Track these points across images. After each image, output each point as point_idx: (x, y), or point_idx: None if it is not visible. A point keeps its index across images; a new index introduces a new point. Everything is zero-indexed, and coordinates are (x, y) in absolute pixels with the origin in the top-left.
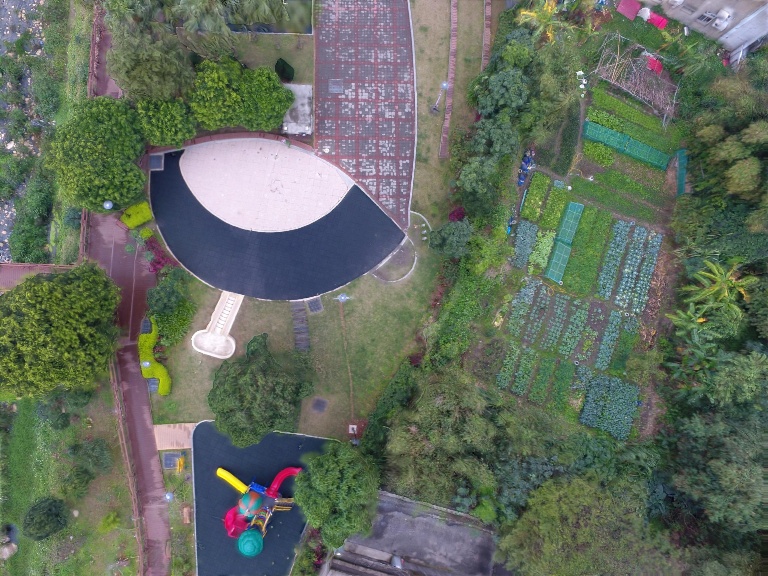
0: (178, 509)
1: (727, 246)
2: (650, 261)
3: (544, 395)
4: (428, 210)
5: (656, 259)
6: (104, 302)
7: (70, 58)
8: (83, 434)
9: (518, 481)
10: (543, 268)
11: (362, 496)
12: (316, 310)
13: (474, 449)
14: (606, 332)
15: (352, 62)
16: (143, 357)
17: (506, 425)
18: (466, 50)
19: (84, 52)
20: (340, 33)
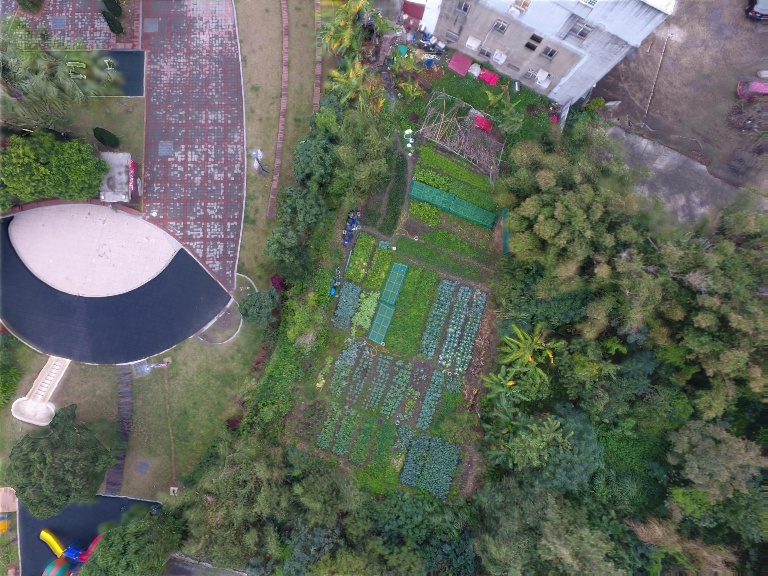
0: (2, 571)
1: (538, 309)
2: (474, 320)
3: (364, 455)
4: (254, 272)
5: (480, 318)
6: None
7: None
8: None
9: (299, 554)
10: (367, 329)
11: (137, 573)
12: (142, 373)
13: (274, 516)
14: (427, 392)
15: (182, 124)
16: None
17: (302, 494)
18: (296, 109)
19: None
20: (171, 95)
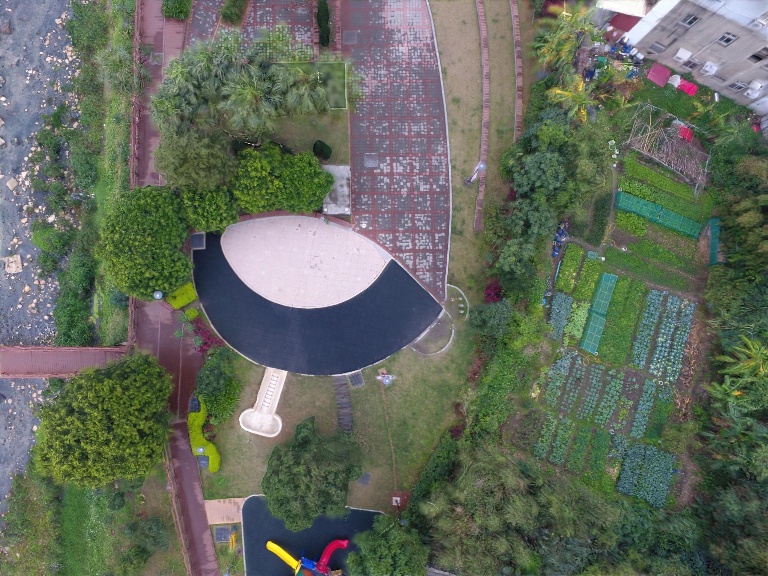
0: None
1: (761, 319)
2: (683, 329)
3: (581, 464)
4: (464, 283)
5: (689, 327)
6: (159, 393)
7: (108, 135)
8: (136, 510)
9: (564, 564)
10: (578, 339)
11: None
12: (357, 384)
13: None
14: (641, 401)
15: (386, 136)
16: (193, 436)
17: (549, 504)
18: (498, 121)
19: (124, 132)
20: (374, 106)
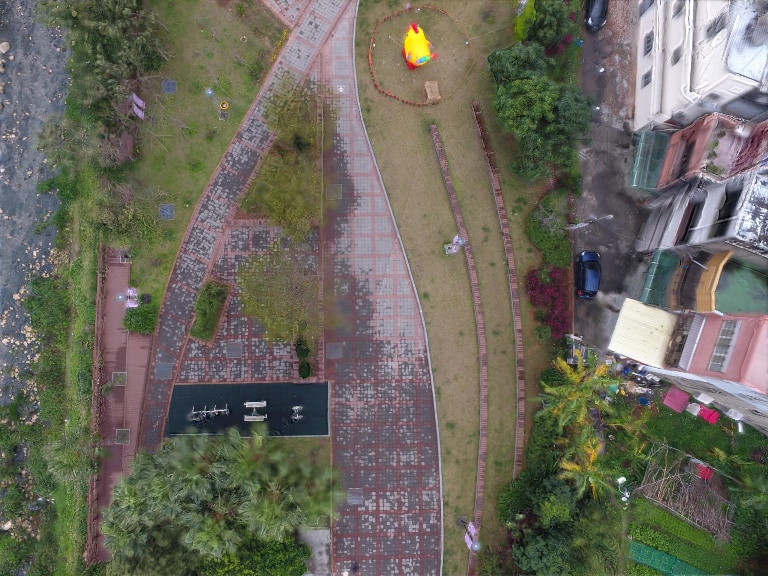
0: None
1: None
2: None
3: None
4: None
5: None
6: None
7: None
8: None
9: None
10: None
11: None
12: None
13: None
14: None
15: (372, 467)
16: None
17: None
18: (497, 451)
19: (82, 465)
20: (359, 432)
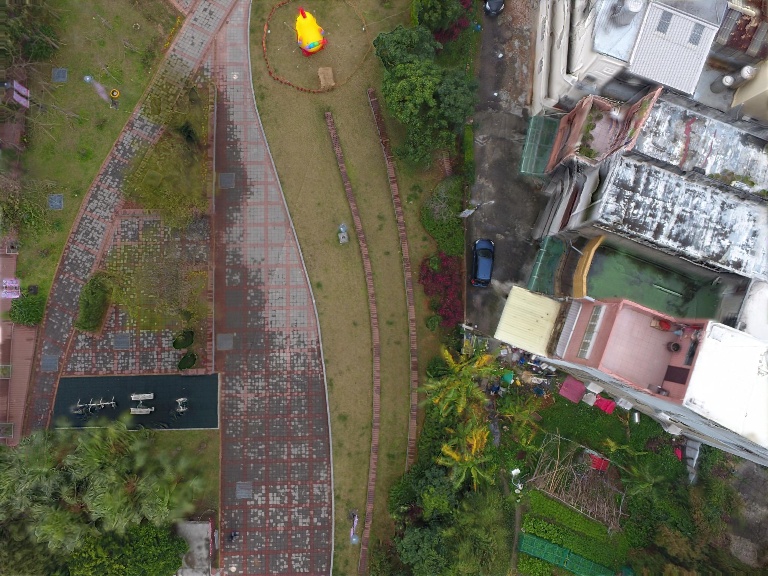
0: None
1: None
2: None
3: None
4: None
5: None
6: None
7: None
8: None
9: None
10: None
11: None
12: None
13: None
14: None
15: (262, 460)
16: None
17: None
18: (389, 443)
19: None
20: (249, 425)
